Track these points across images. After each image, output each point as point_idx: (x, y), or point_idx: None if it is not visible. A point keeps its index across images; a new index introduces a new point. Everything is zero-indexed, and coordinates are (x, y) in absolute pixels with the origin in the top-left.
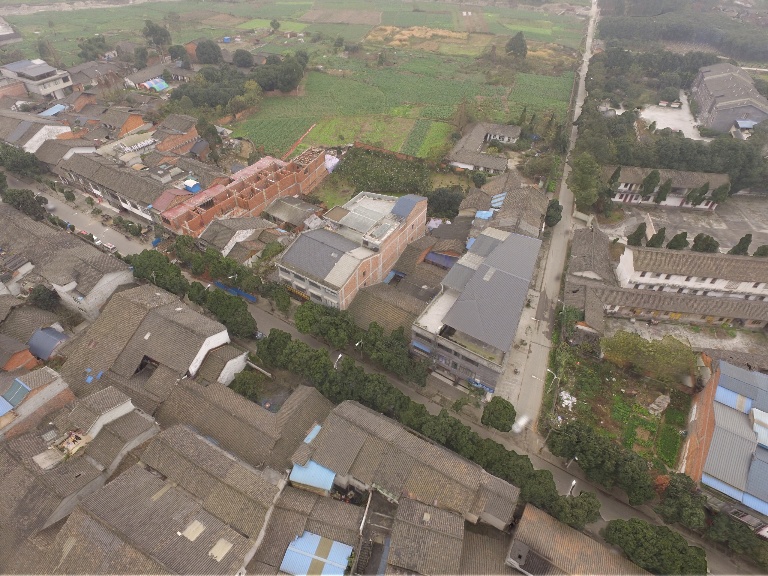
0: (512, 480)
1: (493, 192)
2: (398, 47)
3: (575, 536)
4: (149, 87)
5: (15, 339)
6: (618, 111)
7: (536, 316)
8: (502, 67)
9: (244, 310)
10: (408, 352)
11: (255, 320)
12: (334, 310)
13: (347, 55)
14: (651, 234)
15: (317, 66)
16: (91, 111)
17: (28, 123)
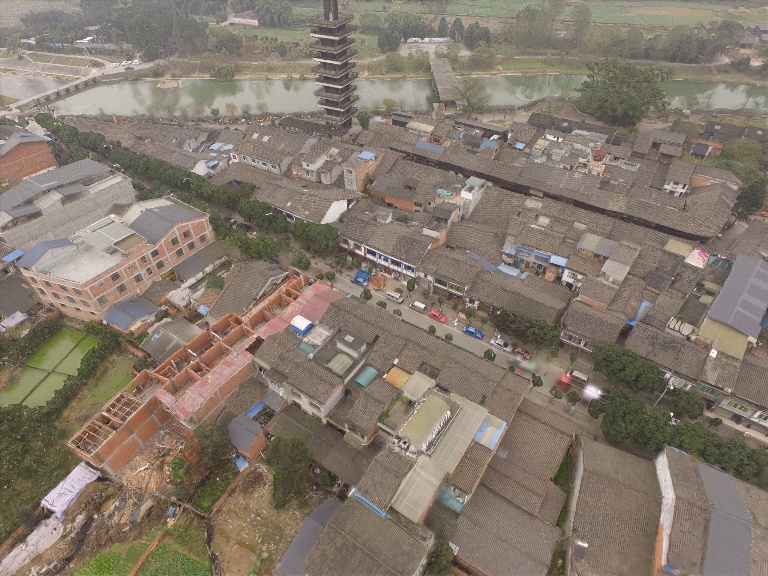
0: None
1: None
2: None
3: None
4: None
5: None
6: None
7: None
8: None
9: None
10: None
11: None
12: None
13: None
14: None
15: None
16: None
17: (729, 511)
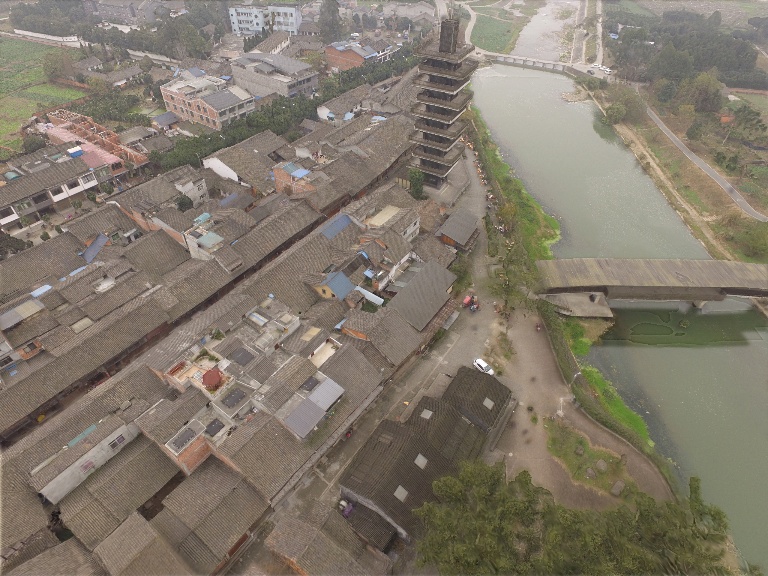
0: None
1: None
2: None
3: None
4: None
5: None
6: None
7: None
8: None
9: None
10: None
11: None
12: (258, 110)
13: None
14: (234, 54)
15: None
16: None
17: None
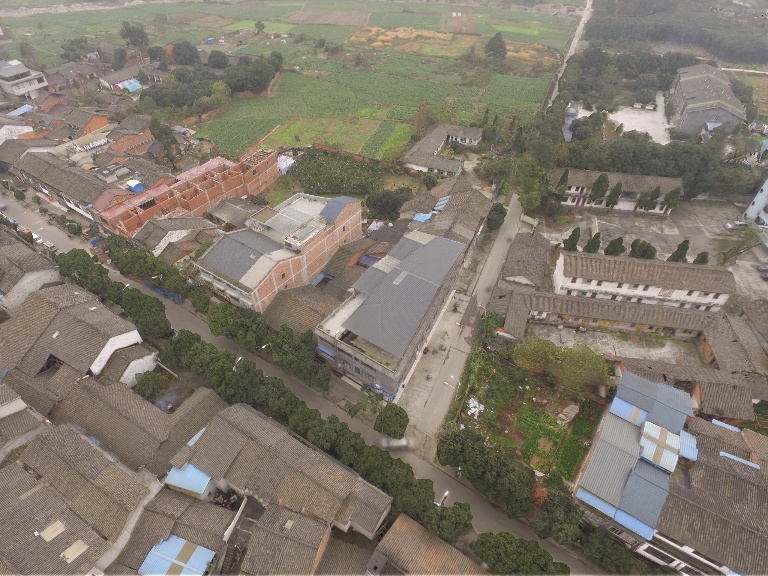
0: (389, 489)
1: (440, 194)
2: (380, 48)
3: (443, 548)
4: (123, 88)
5: None
6: (590, 113)
7: (461, 321)
8: (480, 68)
9: (158, 310)
10: (315, 356)
11: (176, 320)
12: (248, 312)
13: (326, 56)
14: None
15: (294, 67)
16: (59, 111)
17: None
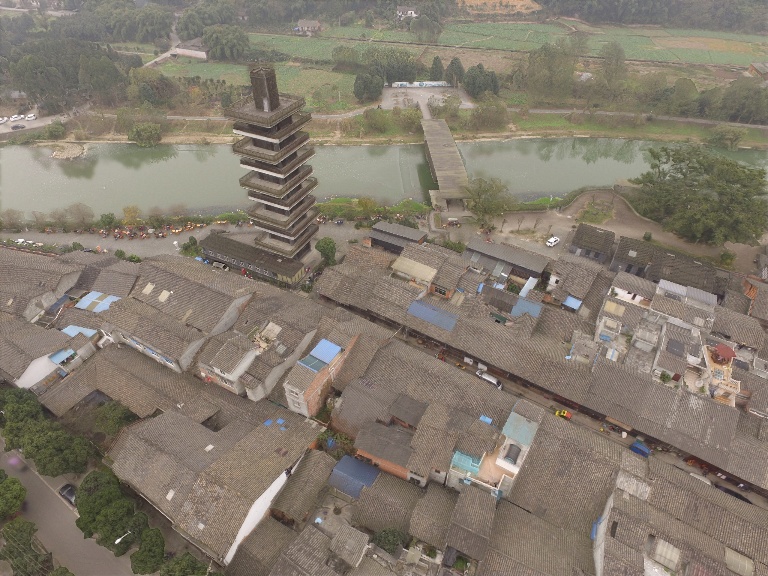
0: None
1: None
2: None
3: None
4: None
5: (397, 482)
6: None
7: None
8: None
9: None
10: None
11: None
12: None
13: None
14: None
15: None
16: None
17: None
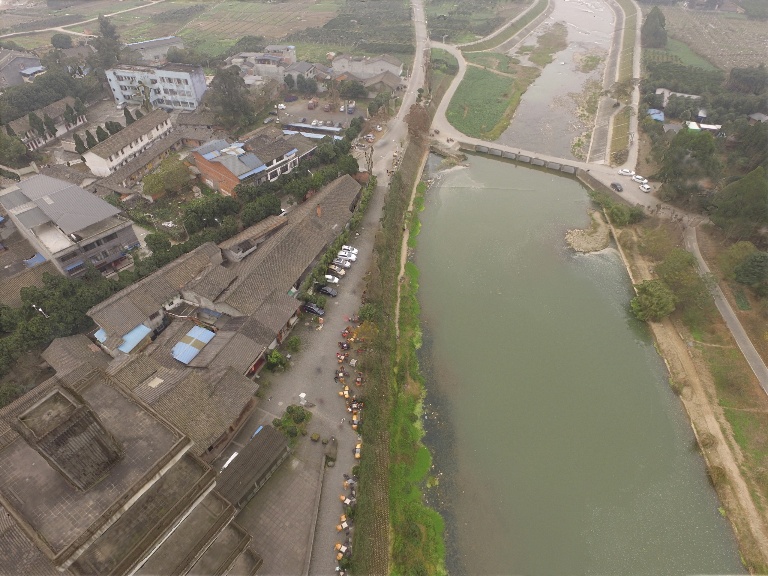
0: None
1: None
2: None
3: None
4: None
5: None
6: None
7: None
8: None
9: None
10: None
11: None
12: None
13: None
14: None
15: None
16: None
17: None
